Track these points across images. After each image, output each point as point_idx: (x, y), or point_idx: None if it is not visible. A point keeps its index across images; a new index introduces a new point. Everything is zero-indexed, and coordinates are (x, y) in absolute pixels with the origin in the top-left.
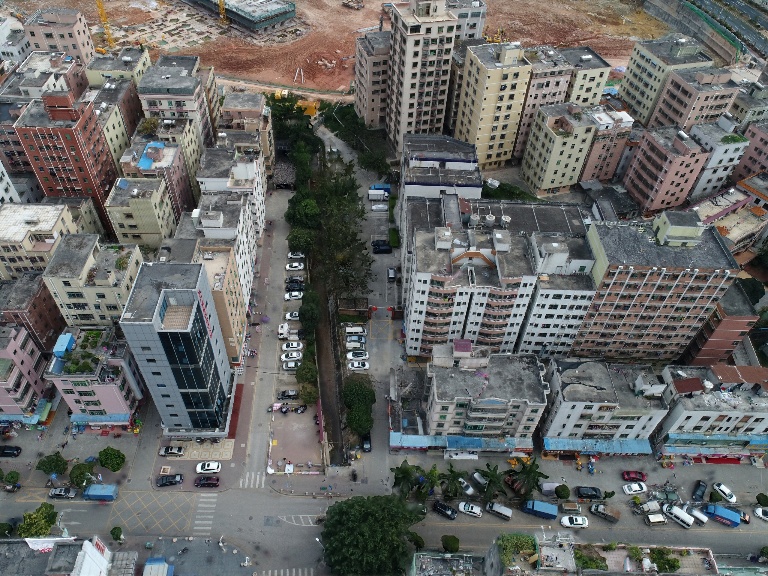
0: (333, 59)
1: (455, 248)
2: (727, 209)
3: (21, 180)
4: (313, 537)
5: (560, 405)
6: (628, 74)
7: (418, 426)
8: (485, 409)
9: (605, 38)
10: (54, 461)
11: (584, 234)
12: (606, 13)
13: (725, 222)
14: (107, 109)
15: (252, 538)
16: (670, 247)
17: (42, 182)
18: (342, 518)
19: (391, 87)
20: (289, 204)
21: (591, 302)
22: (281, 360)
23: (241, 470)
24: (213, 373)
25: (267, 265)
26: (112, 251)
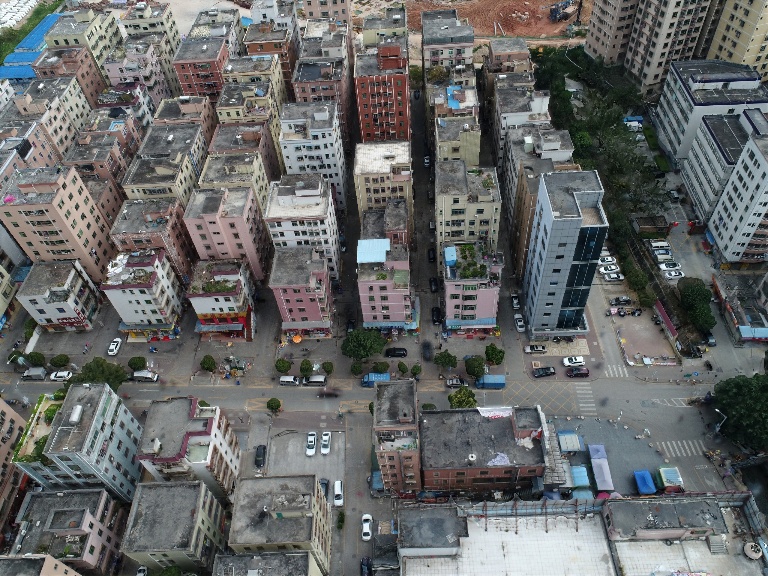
0: (525, 11)
1: None
2: None
3: None
4: (691, 415)
5: None
6: None
7: (763, 320)
8: None
9: None
10: (447, 357)
11: None
12: None
13: None
14: None
15: (636, 417)
16: None
17: (363, 128)
18: (743, 390)
19: (642, 20)
20: None
21: None
22: (600, 273)
23: (602, 363)
24: None
25: None
26: (473, 175)
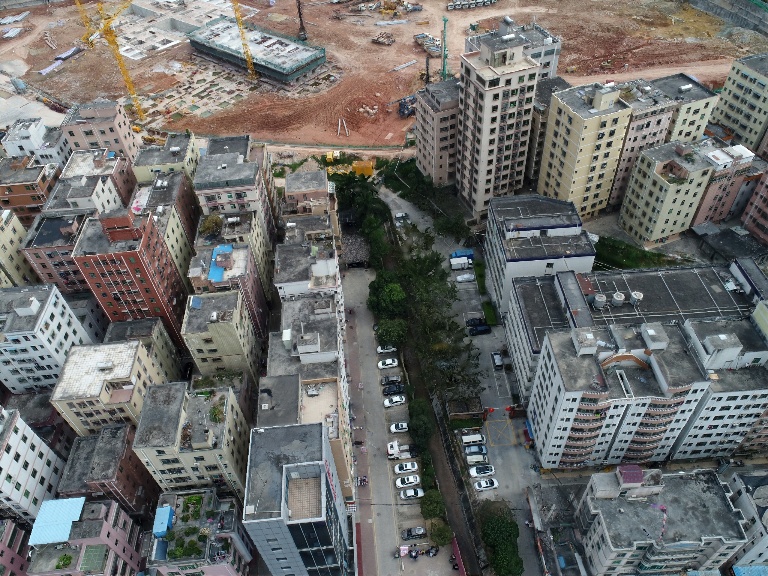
0: (374, 104)
1: (601, 352)
2: None
3: (80, 303)
4: None
5: (761, 537)
6: (726, 96)
7: (578, 565)
8: (671, 552)
9: (659, 43)
10: None
11: (748, 315)
12: (652, 15)
13: None
14: (164, 212)
15: None
16: None
17: (105, 307)
18: None
19: (463, 143)
20: (370, 290)
21: None
22: (396, 487)
23: None
24: (339, 537)
25: (356, 365)
26: (202, 398)
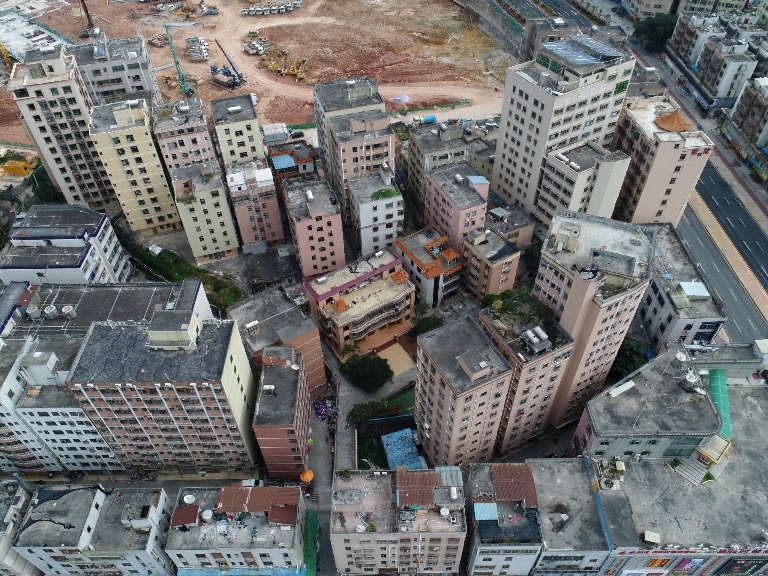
0: None
1: None
2: (360, 277)
3: None
4: None
5: None
6: None
7: None
8: None
9: (414, 61)
10: None
11: None
12: (431, 32)
13: (365, 291)
14: None
15: None
16: (165, 352)
17: None
18: None
19: None
20: None
21: (88, 418)
22: None
23: None
24: None
25: None
26: None
